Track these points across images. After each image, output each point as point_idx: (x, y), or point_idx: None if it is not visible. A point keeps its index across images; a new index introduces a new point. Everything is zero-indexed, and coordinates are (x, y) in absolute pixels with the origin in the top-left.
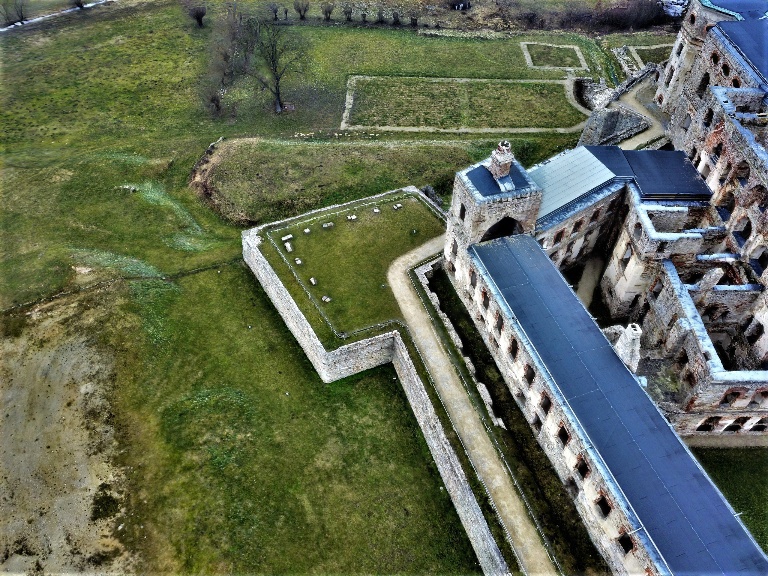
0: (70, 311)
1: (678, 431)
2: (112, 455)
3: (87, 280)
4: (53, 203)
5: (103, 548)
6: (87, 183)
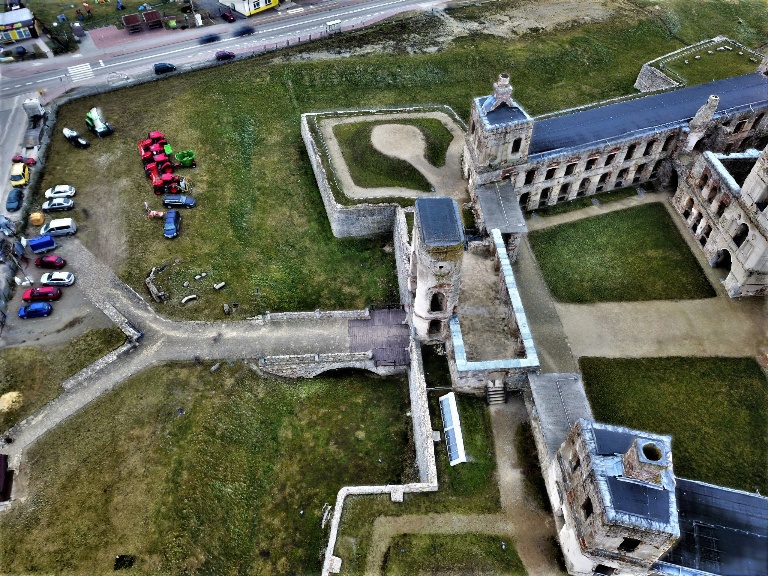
0: (628, 8)
1: (677, 203)
2: (558, 28)
3: (651, 9)
4: (705, 2)
5: (518, 32)
6: (733, 9)
